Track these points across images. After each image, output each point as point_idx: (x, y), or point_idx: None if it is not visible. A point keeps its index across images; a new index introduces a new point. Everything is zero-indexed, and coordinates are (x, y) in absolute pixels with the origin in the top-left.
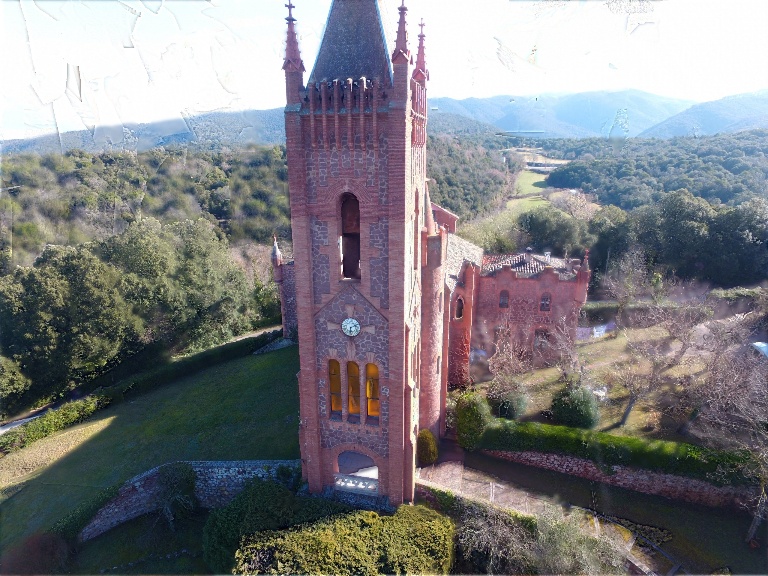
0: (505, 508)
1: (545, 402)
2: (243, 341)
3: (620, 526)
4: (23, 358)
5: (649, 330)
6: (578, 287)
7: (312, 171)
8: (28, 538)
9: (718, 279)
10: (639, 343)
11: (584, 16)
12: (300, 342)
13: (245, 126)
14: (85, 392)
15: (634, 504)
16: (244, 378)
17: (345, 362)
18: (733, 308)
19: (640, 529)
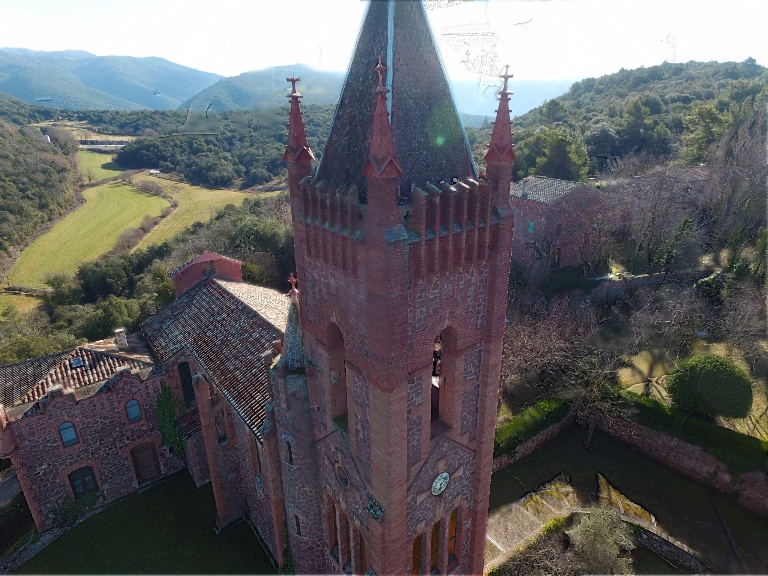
0: (524, 543)
1: None
2: None
3: (549, 491)
4: None
5: None
6: None
7: (408, 316)
8: None
9: None
10: None
11: None
12: (392, 546)
13: None
14: None
15: (536, 467)
16: None
17: None
18: None
19: (556, 483)
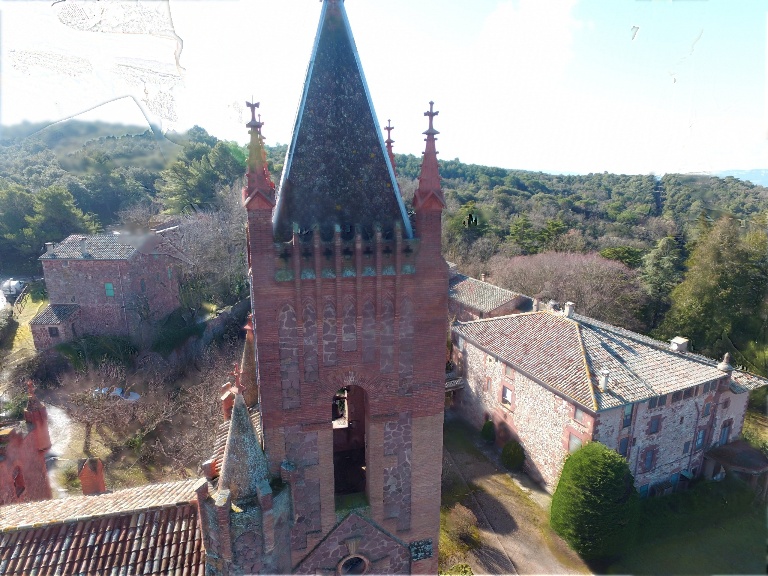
0: None
1: None
2: None
3: None
4: None
5: None
6: (40, 432)
7: None
8: None
9: None
10: None
11: None
12: None
13: None
14: None
15: None
16: None
17: None
18: None
19: None
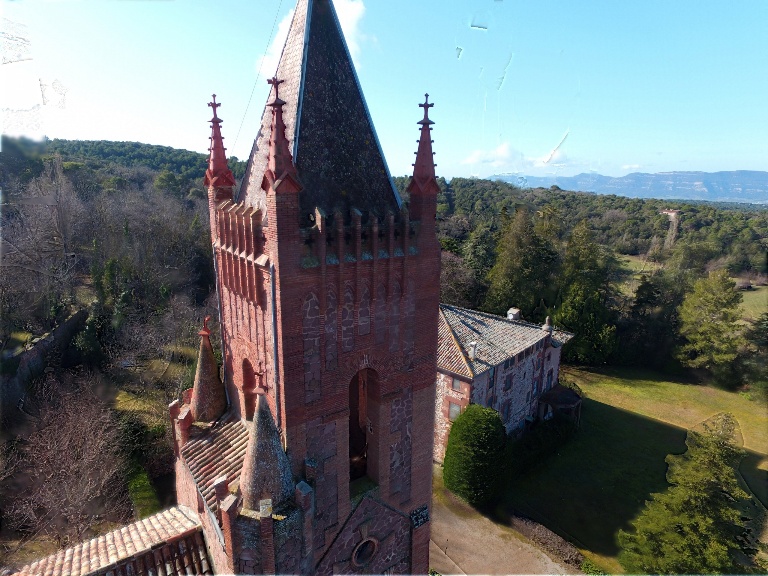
0: None
1: None
2: None
3: None
4: None
5: None
6: None
7: None
8: None
9: None
10: None
11: None
12: None
13: None
14: None
15: None
16: None
17: None
18: None
19: None
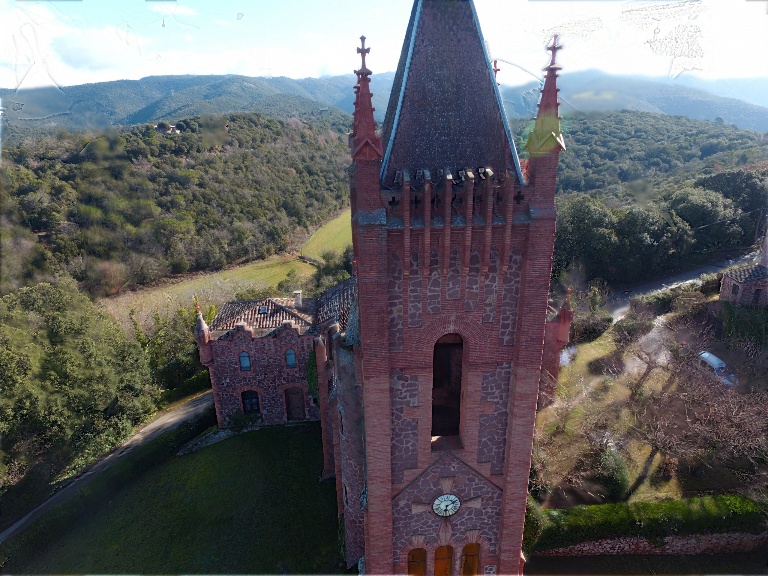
0: None
1: (561, 464)
2: (159, 441)
3: None
4: None
5: (595, 344)
6: (561, 327)
7: (397, 307)
8: None
9: (624, 279)
10: (597, 363)
11: (620, 53)
12: (372, 540)
13: (95, 137)
14: None
15: (692, 574)
16: (184, 505)
17: (435, 548)
18: (653, 311)
19: None
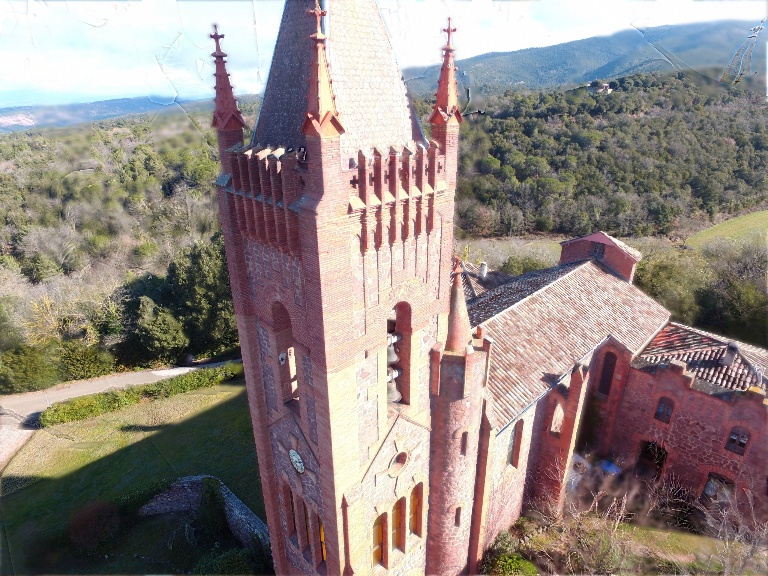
0: None
1: None
2: None
3: None
4: (186, 320)
5: None
6: None
7: (250, 262)
8: (114, 493)
9: None
10: None
11: None
12: None
13: None
14: (232, 355)
15: None
16: None
17: (296, 493)
18: None
19: None
